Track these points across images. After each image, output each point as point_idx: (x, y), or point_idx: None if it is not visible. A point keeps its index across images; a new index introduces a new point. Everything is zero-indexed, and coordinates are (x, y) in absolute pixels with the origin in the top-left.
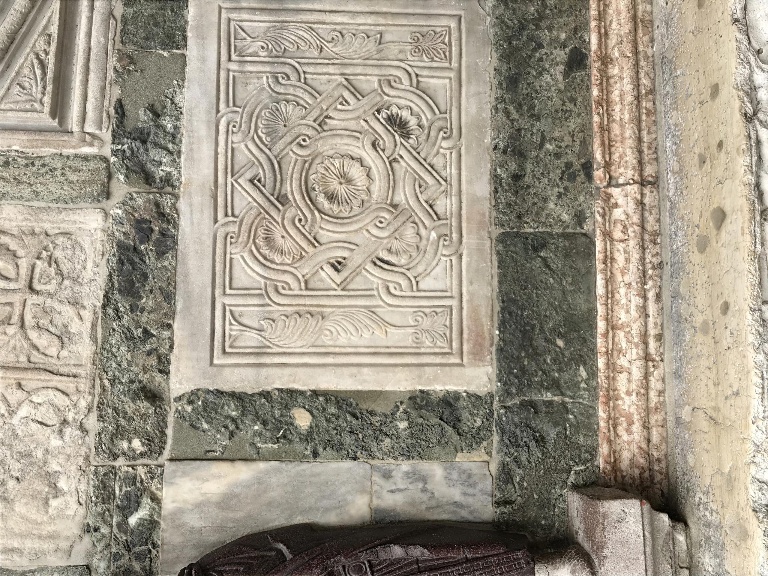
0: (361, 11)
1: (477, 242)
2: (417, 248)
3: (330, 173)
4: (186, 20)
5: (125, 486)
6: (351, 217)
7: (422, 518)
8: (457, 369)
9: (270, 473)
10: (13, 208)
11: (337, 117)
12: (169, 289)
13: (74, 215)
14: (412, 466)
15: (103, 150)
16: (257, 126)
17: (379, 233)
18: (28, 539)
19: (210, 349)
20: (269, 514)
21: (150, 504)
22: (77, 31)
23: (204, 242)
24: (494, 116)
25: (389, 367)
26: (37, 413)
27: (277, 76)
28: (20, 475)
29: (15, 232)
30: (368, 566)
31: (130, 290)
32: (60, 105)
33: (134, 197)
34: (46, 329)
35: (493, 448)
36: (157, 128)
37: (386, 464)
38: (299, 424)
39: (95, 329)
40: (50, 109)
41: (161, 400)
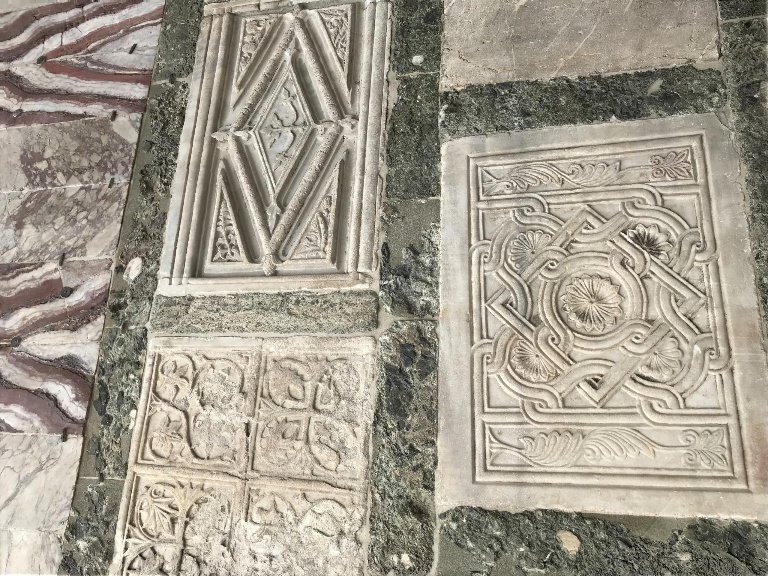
0: (599, 144)
1: (749, 355)
2: (680, 363)
3: (580, 293)
4: (440, 172)
5: None
6: (605, 334)
7: None
8: (743, 495)
9: None
10: (302, 339)
11: (583, 240)
12: (432, 408)
13: (350, 343)
14: None
15: (373, 286)
16: (506, 255)
17: (636, 349)
18: None
19: (472, 466)
20: None
21: None
22: (351, 191)
23: (462, 363)
24: (752, 225)
25: (661, 490)
26: (318, 523)
27: (523, 209)
28: None
29: (302, 359)
30: None
31: (397, 409)
32: (338, 252)
33: (399, 325)
34: (326, 445)
35: None
36: (417, 264)
37: None
38: (567, 549)
39: (367, 445)
40: (331, 255)
41: (427, 516)
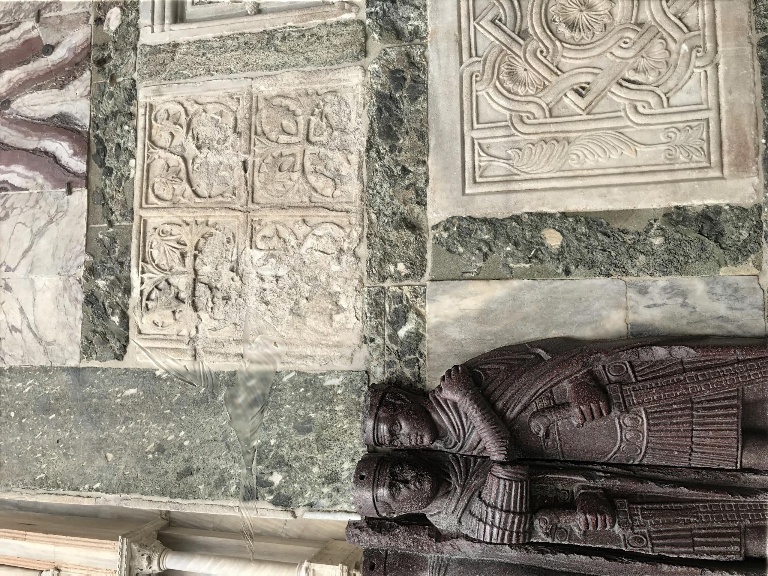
0: None
1: (735, 49)
2: (666, 64)
3: (570, 3)
4: None
5: (393, 304)
6: (594, 42)
7: (683, 333)
8: (717, 182)
9: (524, 290)
10: (291, 75)
11: None
12: (422, 130)
13: (339, 74)
14: (670, 282)
15: (359, 15)
16: None
17: (624, 54)
18: (318, 348)
19: (462, 181)
20: (524, 328)
21: (416, 319)
22: None
23: (451, 84)
24: None
25: (641, 185)
26: (319, 244)
27: None
28: (308, 296)
29: (293, 96)
30: (629, 366)
31: (389, 134)
32: None
33: (388, 52)
34: (322, 173)
35: (763, 261)
36: None
37: (641, 280)
38: (550, 244)
39: (361, 171)
40: None
41: (420, 229)
